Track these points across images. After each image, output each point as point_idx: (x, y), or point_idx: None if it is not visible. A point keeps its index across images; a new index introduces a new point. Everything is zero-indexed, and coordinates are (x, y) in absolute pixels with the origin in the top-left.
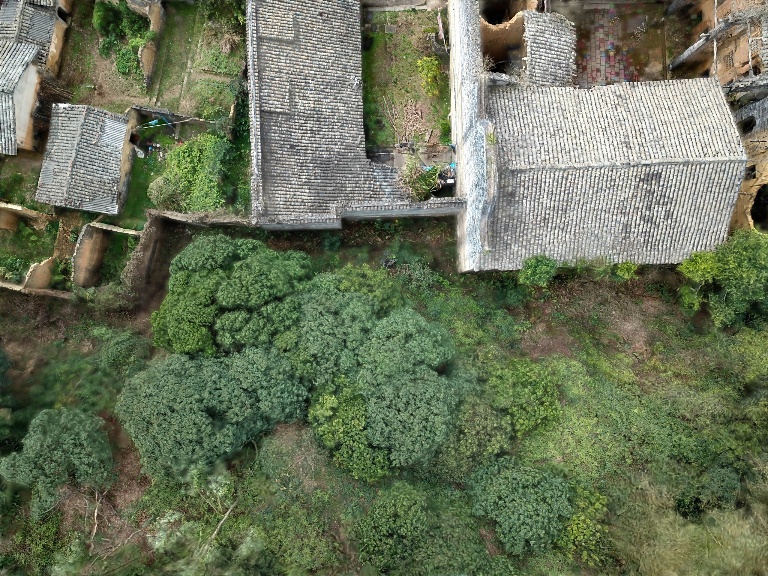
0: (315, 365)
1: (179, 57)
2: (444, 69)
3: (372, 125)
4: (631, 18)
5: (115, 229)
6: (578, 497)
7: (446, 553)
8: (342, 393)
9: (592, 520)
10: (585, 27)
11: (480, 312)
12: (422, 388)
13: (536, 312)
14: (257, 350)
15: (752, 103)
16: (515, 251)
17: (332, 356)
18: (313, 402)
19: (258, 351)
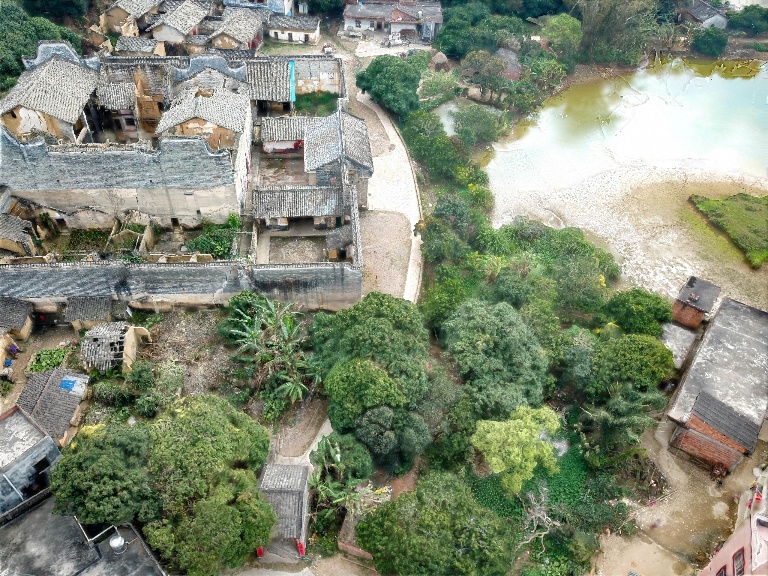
0: (4, 36)
1: None
2: None
3: None
4: None
5: (104, 43)
6: None
7: None
8: None
9: None
10: None
11: None
12: None
13: None
14: None
15: None
16: None
17: None
18: None
19: (17, 25)
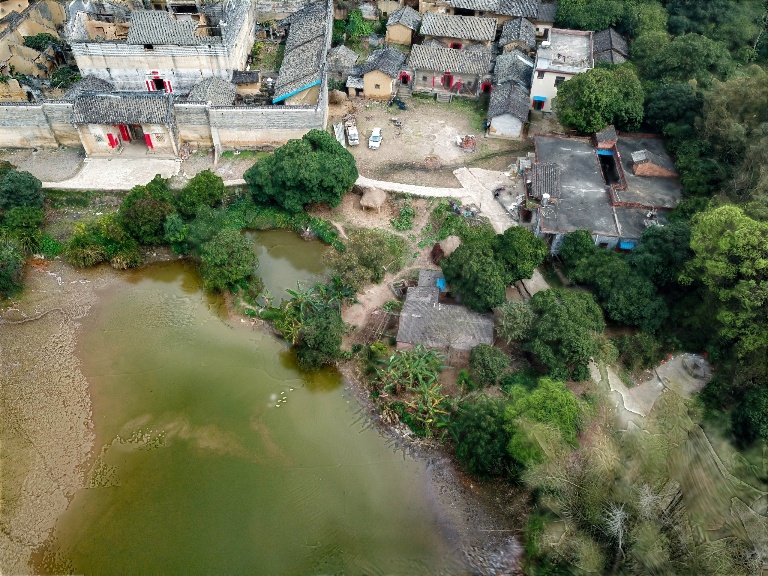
0: None
1: None
2: None
3: None
4: None
5: (388, 1)
6: None
7: None
8: None
9: None
10: None
11: None
12: None
13: None
14: None
15: None
16: None
17: None
18: None
19: None
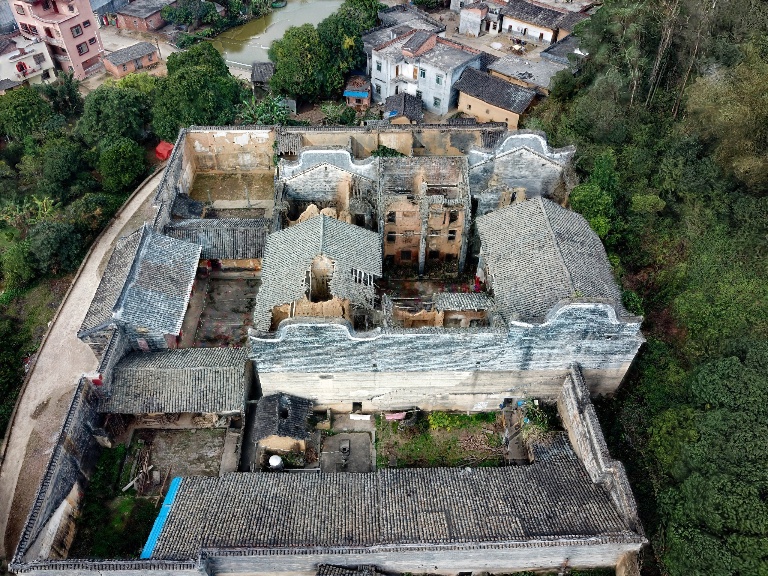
0: None
1: None
2: None
3: None
4: None
5: None
6: None
7: None
8: None
9: None
10: None
11: None
12: (767, 360)
13: None
14: None
15: (477, 213)
16: None
17: None
18: None
19: None
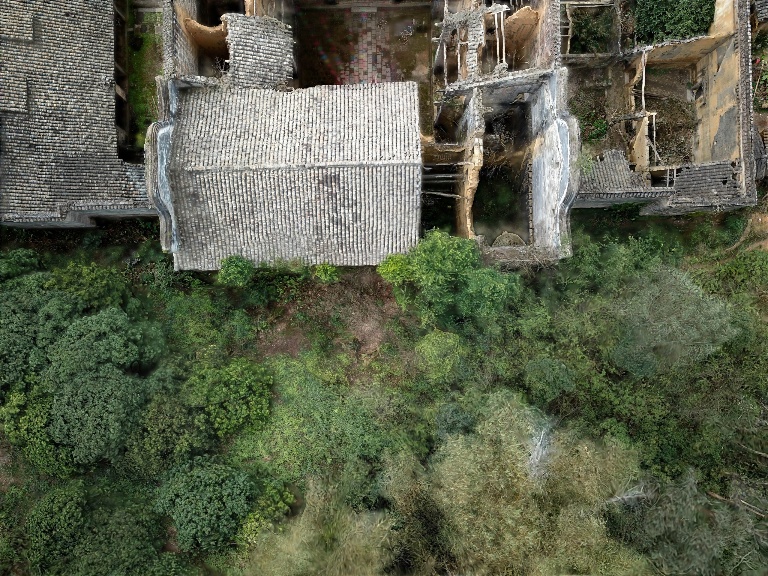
0: (2, 362)
1: None
2: None
3: (141, 125)
4: (398, 21)
5: None
6: (264, 495)
7: (104, 549)
8: (33, 390)
9: (267, 518)
10: (353, 30)
11: (215, 312)
12: (101, 386)
13: (275, 312)
14: None
15: (467, 107)
16: (212, 251)
17: (21, 354)
18: (7, 399)
19: None
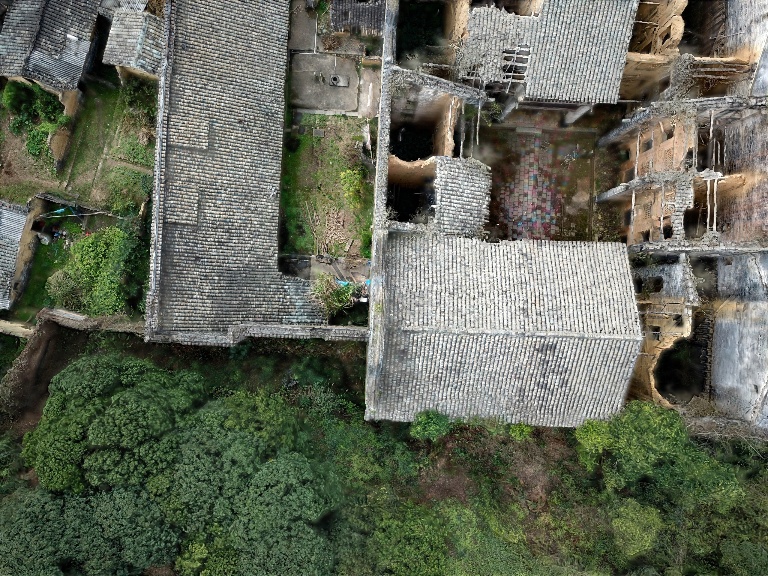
0: (186, 513)
1: (95, 141)
2: (370, 179)
3: (292, 229)
4: (562, 145)
5: (1, 330)
6: None
7: None
8: (213, 542)
9: None
10: (516, 150)
11: (377, 445)
12: (294, 548)
13: (435, 447)
14: (124, 494)
15: (662, 264)
16: (407, 404)
17: (205, 504)
18: (183, 547)
19: (125, 496)
